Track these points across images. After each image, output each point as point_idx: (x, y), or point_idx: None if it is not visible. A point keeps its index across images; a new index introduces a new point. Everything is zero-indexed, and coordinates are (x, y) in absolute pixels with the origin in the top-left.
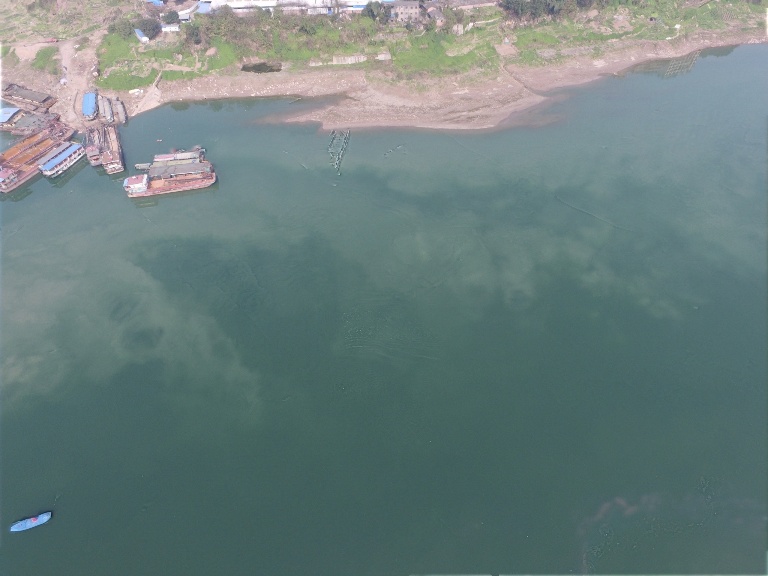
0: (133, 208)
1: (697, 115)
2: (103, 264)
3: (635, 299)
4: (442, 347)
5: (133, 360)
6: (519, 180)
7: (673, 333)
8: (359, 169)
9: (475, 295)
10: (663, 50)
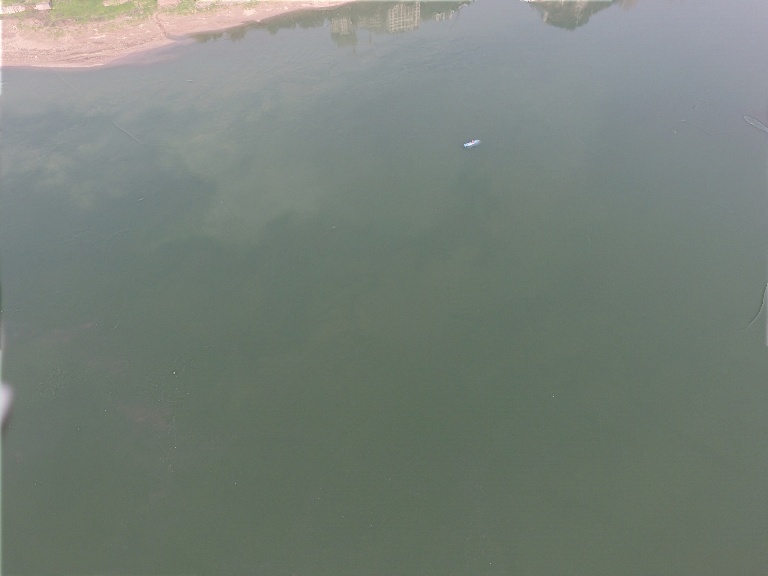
0: None
1: (298, 54)
2: None
3: None
4: None
5: None
6: (90, 108)
7: (97, 217)
8: None
9: None
10: (317, 0)
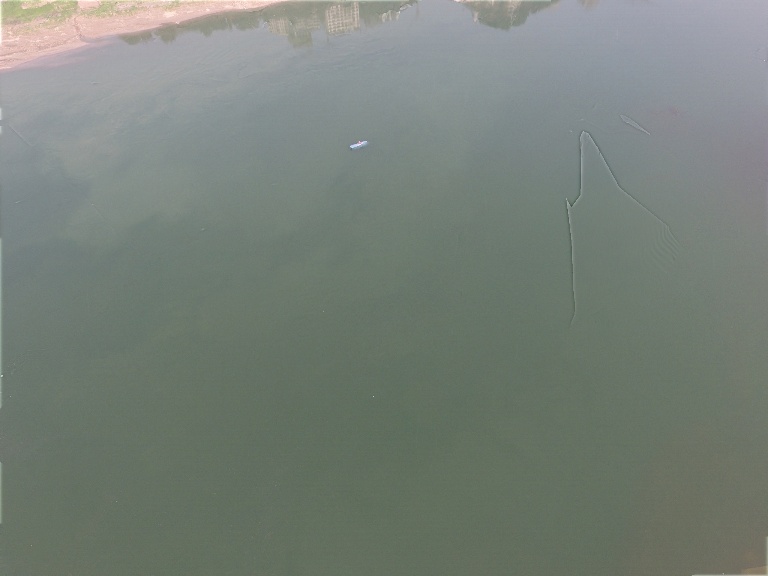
0: None
1: (210, 56)
2: None
3: None
4: None
5: None
6: None
7: None
8: None
9: None
10: (239, 2)
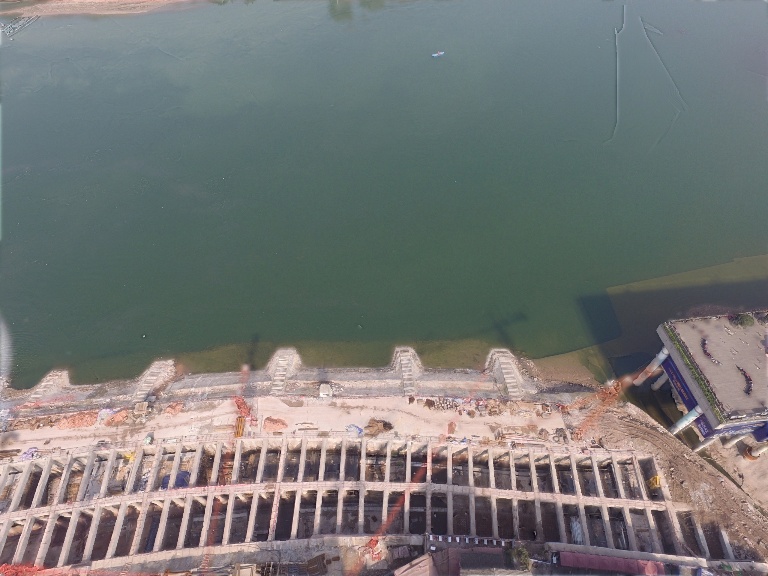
0: None
1: (302, 2)
2: None
3: (155, 91)
4: None
5: None
6: (140, 40)
7: None
8: (30, 37)
9: (56, 94)
10: None
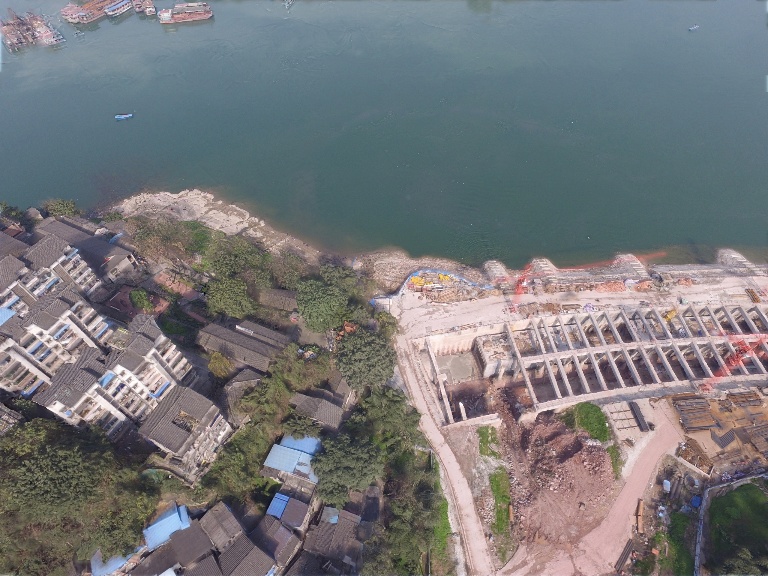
0: (163, 32)
1: None
2: (148, 47)
3: None
4: (331, 67)
5: (168, 74)
6: (401, 15)
7: (459, 64)
8: (302, 11)
9: (358, 57)
10: None
